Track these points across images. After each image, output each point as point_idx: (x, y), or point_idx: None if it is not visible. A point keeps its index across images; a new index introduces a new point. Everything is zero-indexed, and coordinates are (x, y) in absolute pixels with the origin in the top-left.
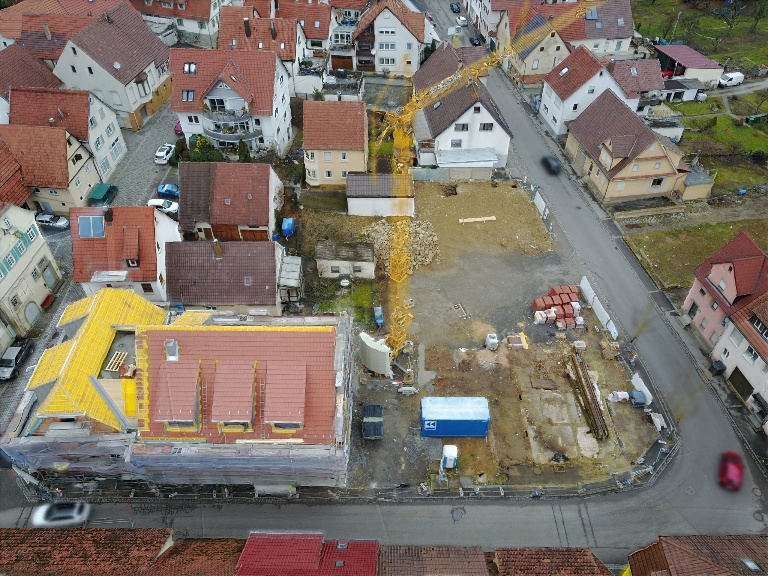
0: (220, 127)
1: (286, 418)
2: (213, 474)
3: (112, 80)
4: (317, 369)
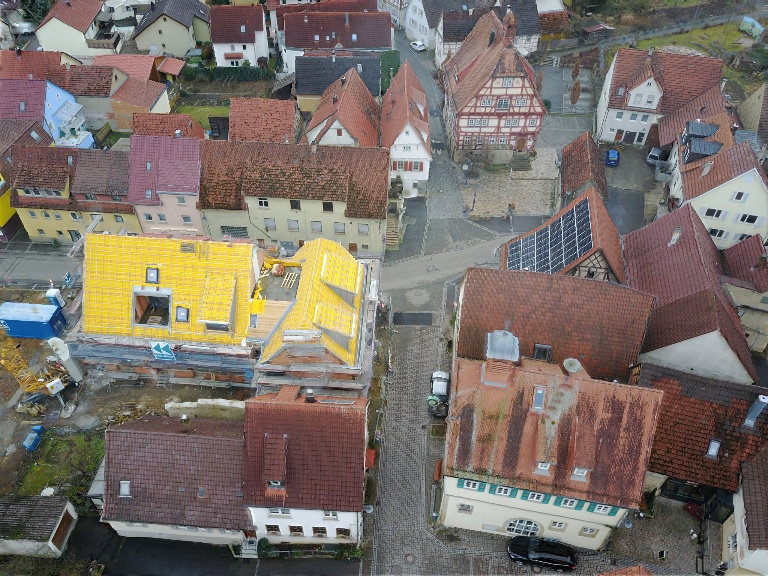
0: None
1: None
2: None
3: None
4: None
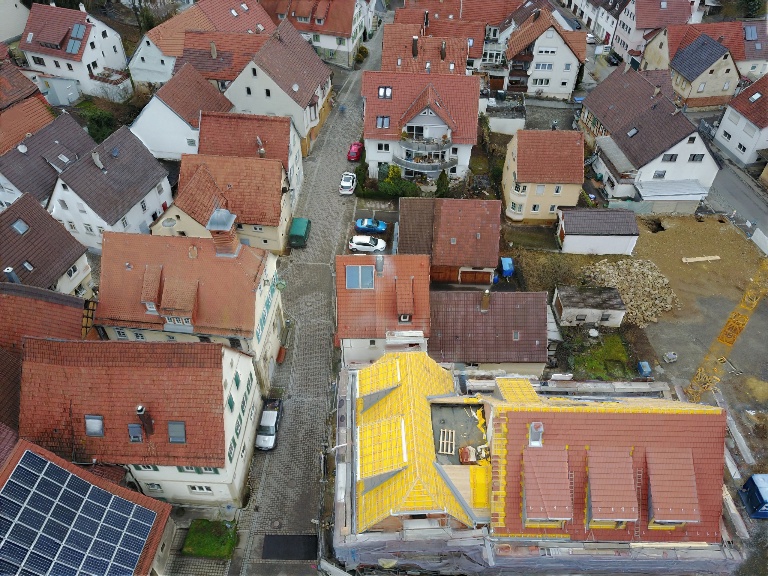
0: (411, 155)
1: (680, 516)
2: (558, 572)
3: (291, 103)
4: (703, 457)
